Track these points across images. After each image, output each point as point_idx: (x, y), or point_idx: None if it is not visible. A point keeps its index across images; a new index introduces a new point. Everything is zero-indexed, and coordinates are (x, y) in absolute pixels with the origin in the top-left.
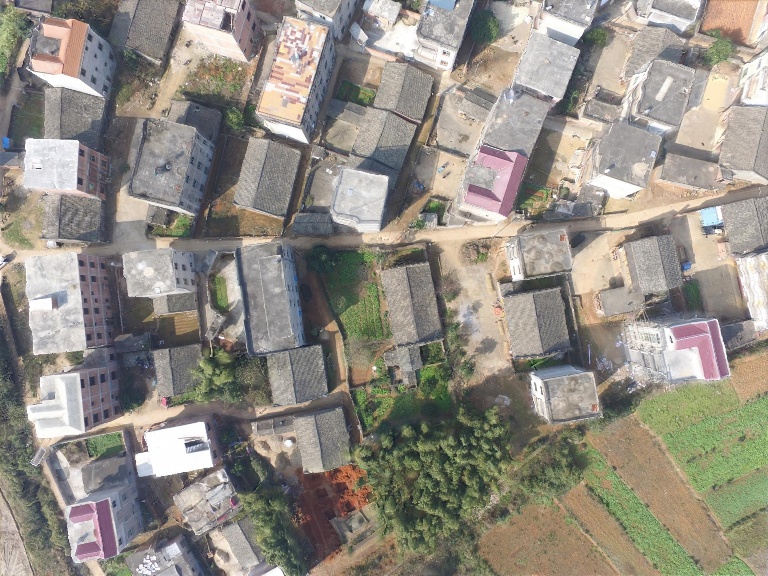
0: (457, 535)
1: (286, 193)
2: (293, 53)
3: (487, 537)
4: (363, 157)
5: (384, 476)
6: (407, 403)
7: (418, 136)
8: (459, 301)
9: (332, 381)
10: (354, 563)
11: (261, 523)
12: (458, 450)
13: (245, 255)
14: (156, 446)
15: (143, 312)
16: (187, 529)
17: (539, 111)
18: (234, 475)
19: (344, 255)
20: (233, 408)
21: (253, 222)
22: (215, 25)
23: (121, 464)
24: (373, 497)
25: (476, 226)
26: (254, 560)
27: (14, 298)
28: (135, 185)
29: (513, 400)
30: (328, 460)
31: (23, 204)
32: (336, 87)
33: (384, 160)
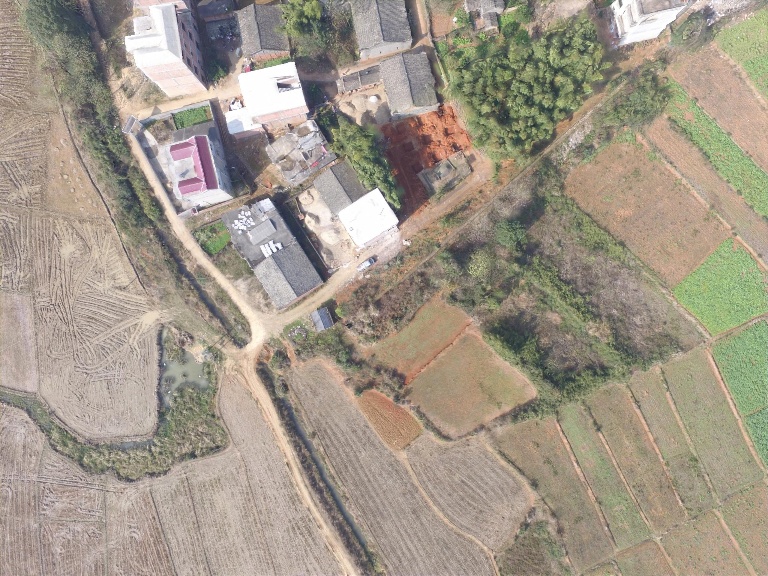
0: (545, 170)
1: None
2: None
3: (573, 177)
4: None
5: (478, 87)
6: (489, 51)
7: None
8: None
9: (414, 36)
10: (443, 214)
11: (358, 143)
12: (552, 46)
13: None
14: (248, 89)
15: None
16: (278, 191)
17: None
18: (323, 127)
19: None
20: (316, 73)
21: None
22: None
23: (211, 126)
24: (459, 149)
25: None
26: (348, 203)
27: None
28: None
29: None
30: (417, 98)
31: None
32: None
33: None
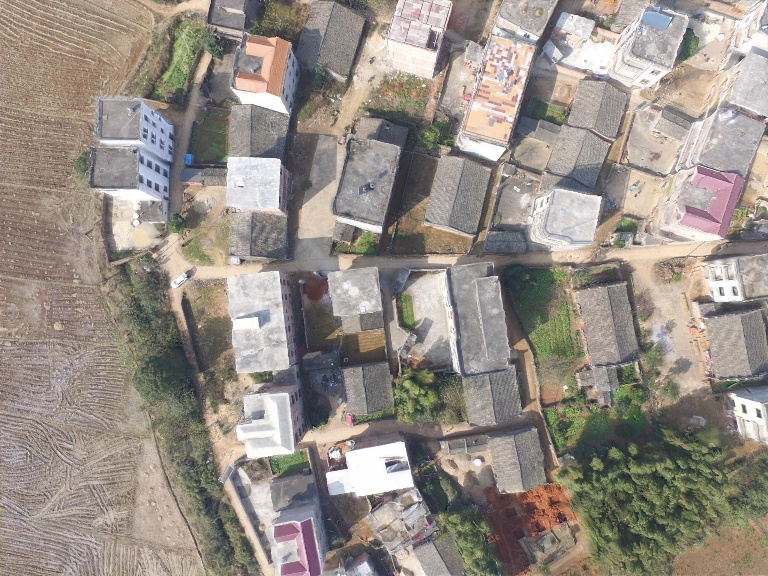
0: None
1: (477, 211)
2: (500, 72)
3: (681, 558)
4: (560, 176)
5: (597, 498)
6: (599, 423)
7: (608, 154)
8: (652, 321)
9: (522, 400)
10: None
11: (470, 544)
12: (678, 473)
13: (455, 275)
14: (355, 465)
15: (326, 329)
16: (374, 548)
17: (755, 131)
18: (426, 494)
19: (533, 273)
20: None
21: (439, 240)
22: (421, 44)
23: (310, 482)
24: (562, 517)
25: (669, 245)
26: None
27: (194, 314)
28: (339, 204)
29: (708, 421)
30: (527, 480)
31: (203, 220)
32: (524, 104)
33: (580, 179)
